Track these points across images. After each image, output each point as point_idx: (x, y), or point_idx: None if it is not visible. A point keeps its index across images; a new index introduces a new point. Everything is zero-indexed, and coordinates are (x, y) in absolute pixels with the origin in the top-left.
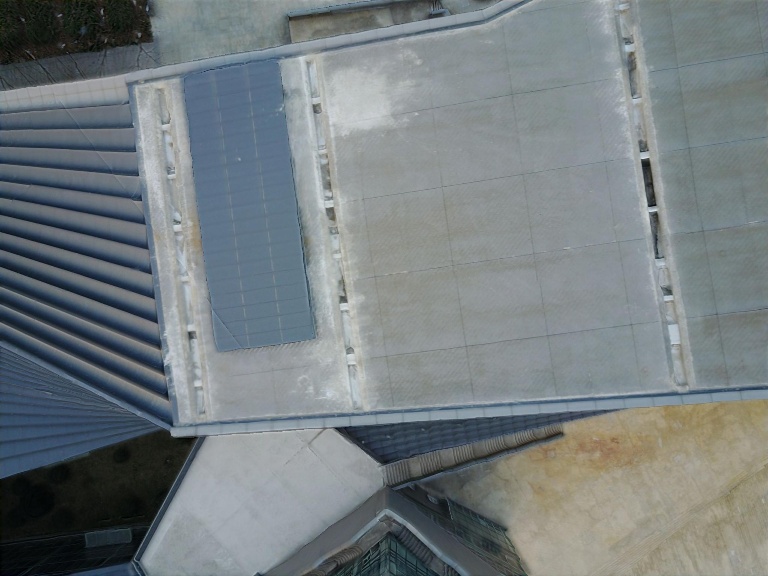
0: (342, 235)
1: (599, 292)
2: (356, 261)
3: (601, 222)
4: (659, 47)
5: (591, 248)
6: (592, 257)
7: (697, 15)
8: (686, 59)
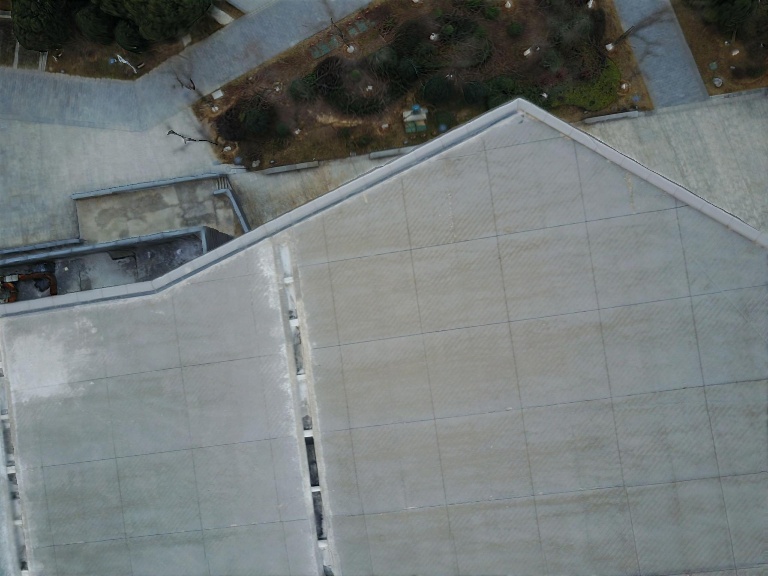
0: (23, 502)
1: (264, 572)
2: (36, 529)
3: (266, 501)
4: (321, 324)
5: (257, 526)
6: (257, 536)
7: (357, 292)
8: (347, 337)
